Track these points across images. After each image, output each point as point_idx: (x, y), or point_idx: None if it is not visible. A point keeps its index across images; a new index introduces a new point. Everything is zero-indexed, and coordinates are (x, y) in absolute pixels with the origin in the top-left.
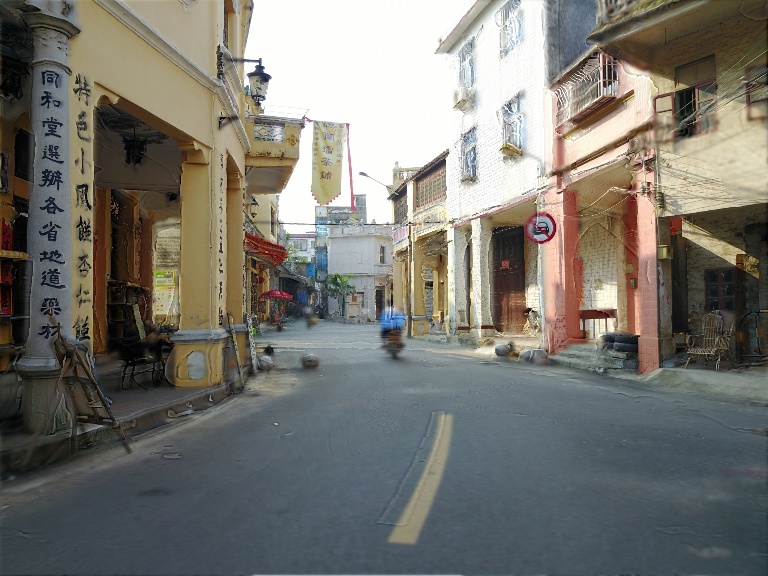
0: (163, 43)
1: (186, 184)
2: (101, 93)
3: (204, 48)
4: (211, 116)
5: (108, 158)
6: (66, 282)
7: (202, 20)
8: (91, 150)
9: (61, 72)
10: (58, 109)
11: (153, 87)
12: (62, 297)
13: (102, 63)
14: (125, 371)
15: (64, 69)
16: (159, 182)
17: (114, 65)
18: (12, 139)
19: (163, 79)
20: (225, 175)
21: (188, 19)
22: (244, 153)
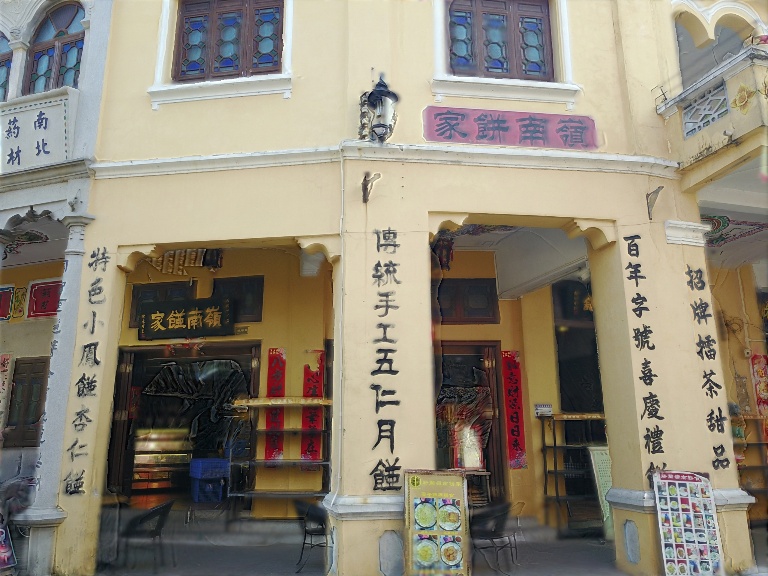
0: (219, 160)
1: (335, 290)
2: (128, 252)
3: (335, 115)
4: (341, 192)
5: (504, 261)
6: (49, 437)
7: (327, 86)
8: (106, 309)
9: (71, 257)
10: (64, 288)
11: (210, 212)
12: (45, 451)
13: (127, 225)
14: (306, 539)
15: (69, 254)
16: (542, 271)
17: (150, 218)
18: (321, 290)
19: (233, 194)
20: (421, 253)
21: (291, 104)
22: (647, 174)
